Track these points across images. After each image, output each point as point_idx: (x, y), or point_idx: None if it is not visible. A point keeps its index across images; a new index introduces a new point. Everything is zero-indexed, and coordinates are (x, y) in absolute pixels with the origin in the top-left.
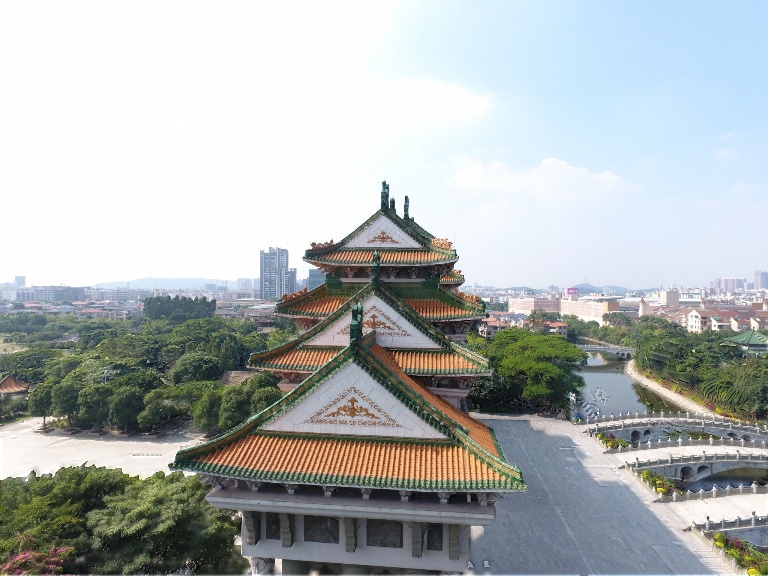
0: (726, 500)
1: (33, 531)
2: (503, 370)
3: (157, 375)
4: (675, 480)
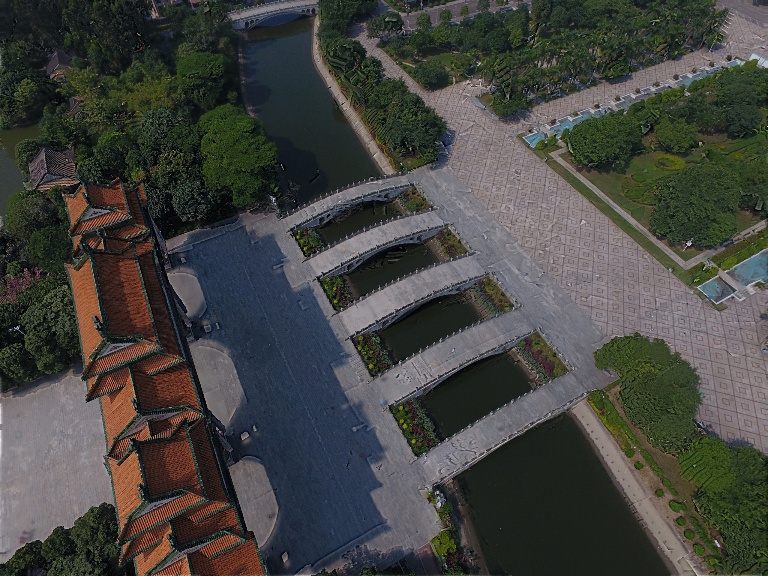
0: (366, 302)
1: None
2: (208, 183)
3: None
4: (344, 272)
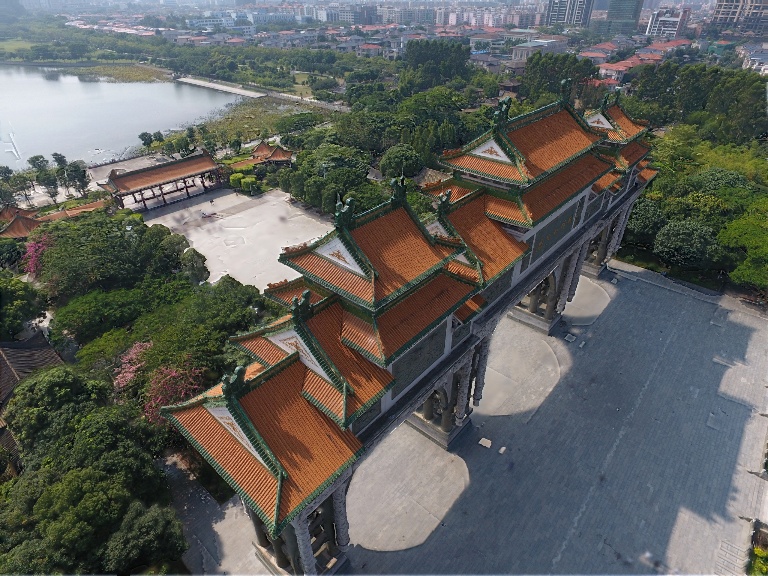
0: None
1: (186, 356)
2: (723, 235)
3: (365, 168)
4: None
